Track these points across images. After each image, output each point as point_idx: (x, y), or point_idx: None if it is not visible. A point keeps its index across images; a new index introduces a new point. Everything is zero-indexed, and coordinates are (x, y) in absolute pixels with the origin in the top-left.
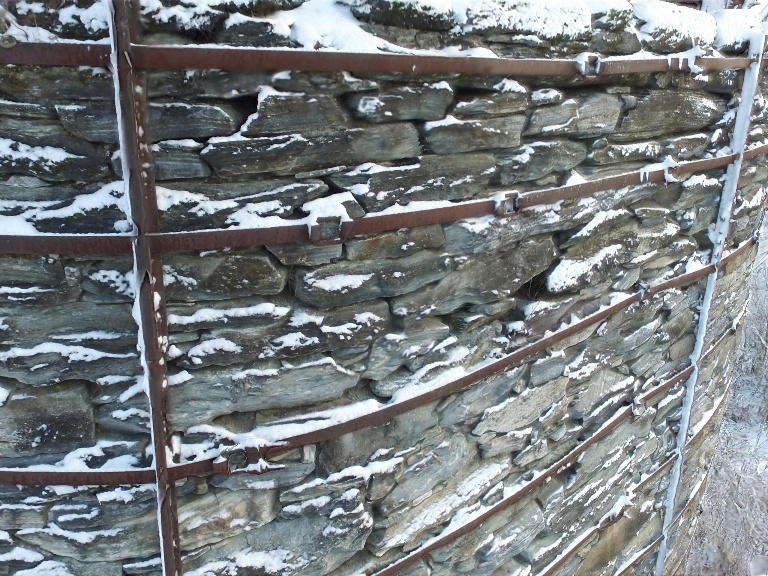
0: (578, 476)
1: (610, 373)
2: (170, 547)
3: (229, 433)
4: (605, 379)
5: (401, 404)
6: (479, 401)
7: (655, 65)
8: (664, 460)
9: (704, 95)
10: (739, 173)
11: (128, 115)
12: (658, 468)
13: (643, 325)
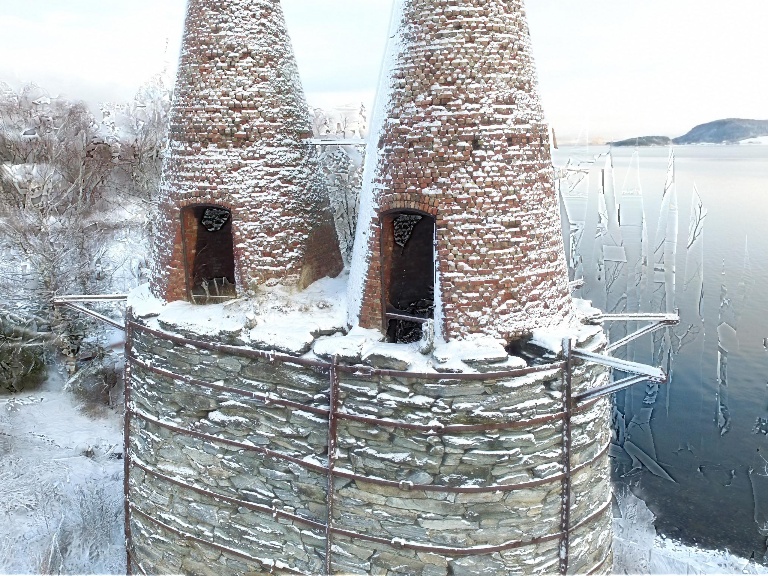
0: (239, 516)
1: (261, 482)
2: (127, 426)
3: (136, 406)
4: (256, 482)
5: (159, 423)
6: (186, 441)
7: (253, 353)
8: (315, 575)
9: (308, 374)
10: (330, 422)
11: (126, 333)
12: (307, 574)
13: (275, 470)
